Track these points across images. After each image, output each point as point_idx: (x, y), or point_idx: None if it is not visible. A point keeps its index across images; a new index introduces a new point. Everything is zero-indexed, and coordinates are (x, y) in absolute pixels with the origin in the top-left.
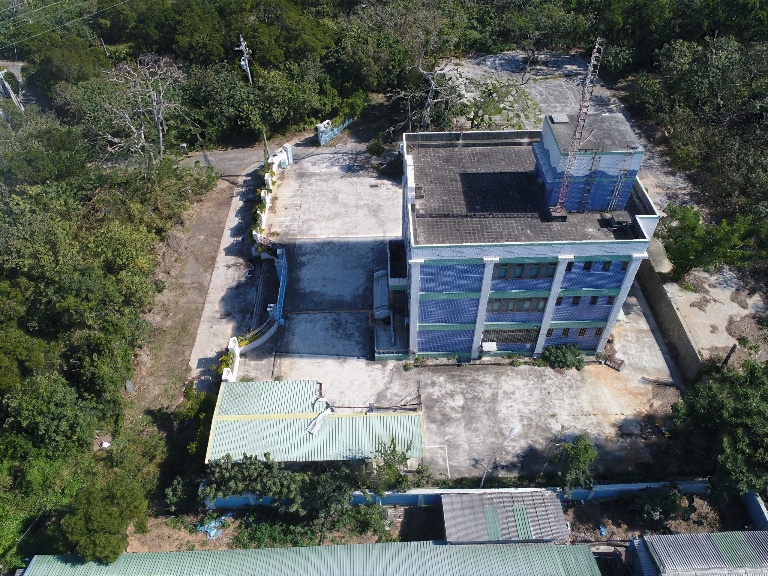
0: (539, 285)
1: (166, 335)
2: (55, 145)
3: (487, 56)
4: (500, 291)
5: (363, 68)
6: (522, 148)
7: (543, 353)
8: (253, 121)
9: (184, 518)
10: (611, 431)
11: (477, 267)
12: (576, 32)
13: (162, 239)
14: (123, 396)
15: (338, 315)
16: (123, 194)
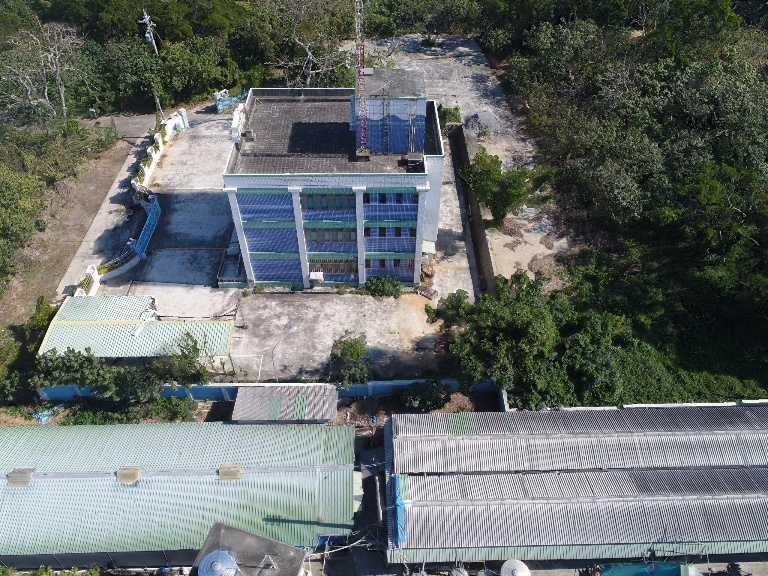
0: (345, 216)
1: (41, 267)
2: None
3: (389, 38)
4: (312, 221)
5: (259, 43)
6: None
7: (366, 283)
8: None
9: (22, 408)
10: (409, 346)
11: (286, 197)
12: (469, 17)
13: (54, 188)
14: None
15: (196, 252)
16: (21, 147)
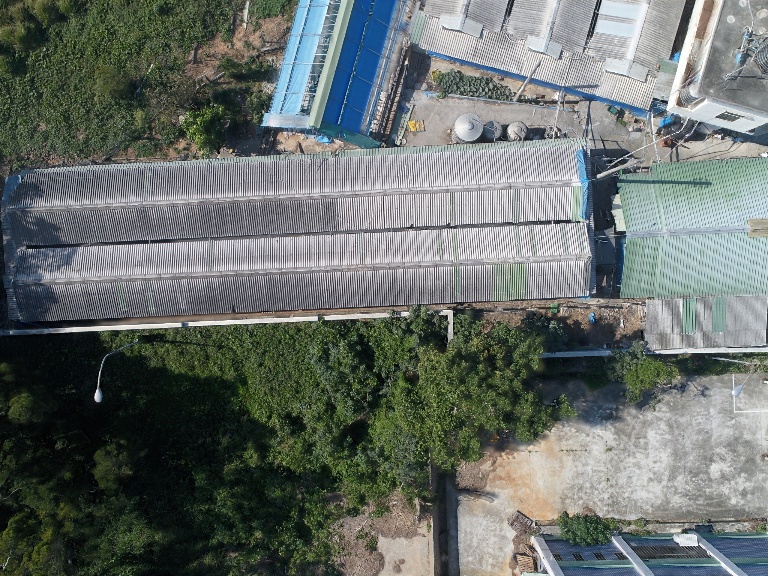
0: None
1: None
2: None
3: None
4: None
5: None
6: None
7: None
8: None
9: None
10: None
11: None
12: None
13: None
14: None
15: None
16: None
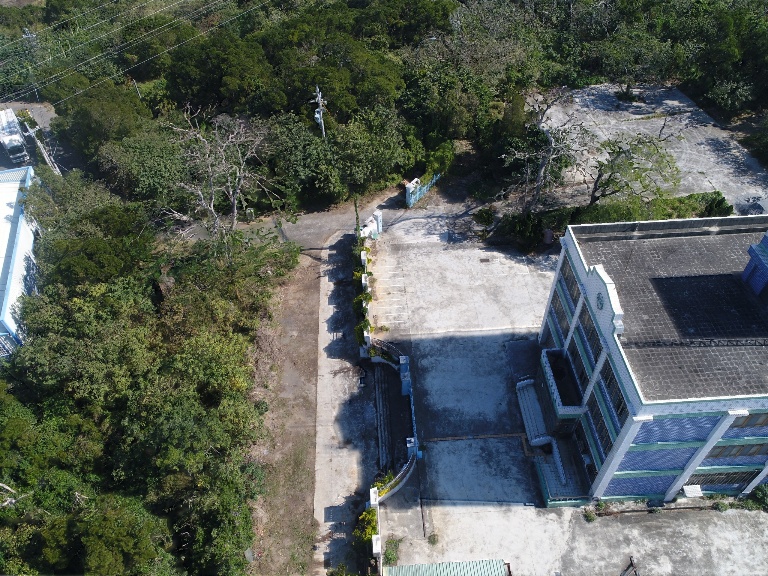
0: None
1: (278, 474)
2: (114, 228)
3: (573, 91)
4: (729, 439)
5: (454, 117)
6: (711, 239)
7: (753, 493)
8: (332, 183)
9: None
10: None
11: (712, 418)
12: (675, 63)
13: (250, 340)
14: (245, 573)
15: (485, 442)
16: (200, 286)
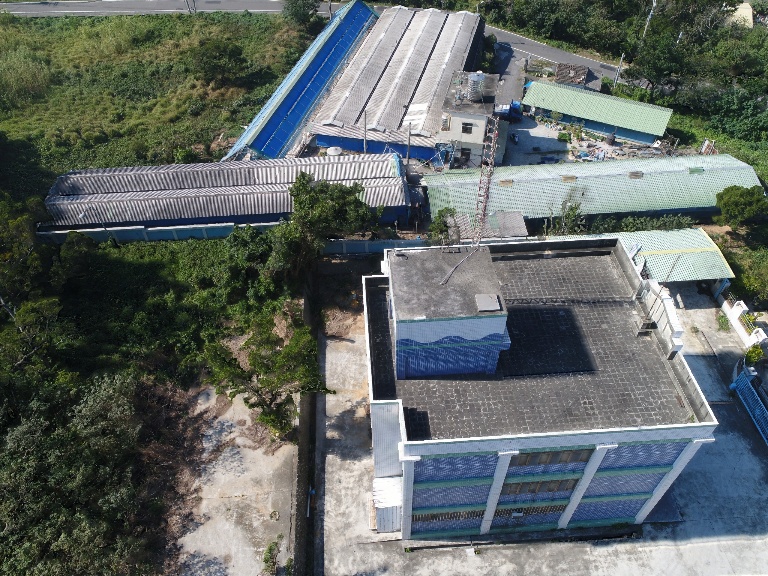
0: None
1: None
2: None
3: None
4: None
5: None
6: None
7: None
8: None
9: None
10: None
11: None
12: None
13: None
14: None
15: None
16: None
